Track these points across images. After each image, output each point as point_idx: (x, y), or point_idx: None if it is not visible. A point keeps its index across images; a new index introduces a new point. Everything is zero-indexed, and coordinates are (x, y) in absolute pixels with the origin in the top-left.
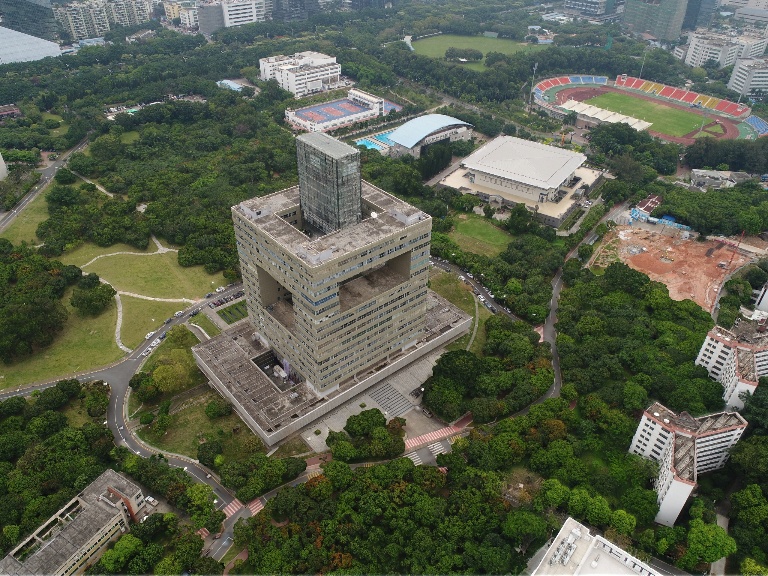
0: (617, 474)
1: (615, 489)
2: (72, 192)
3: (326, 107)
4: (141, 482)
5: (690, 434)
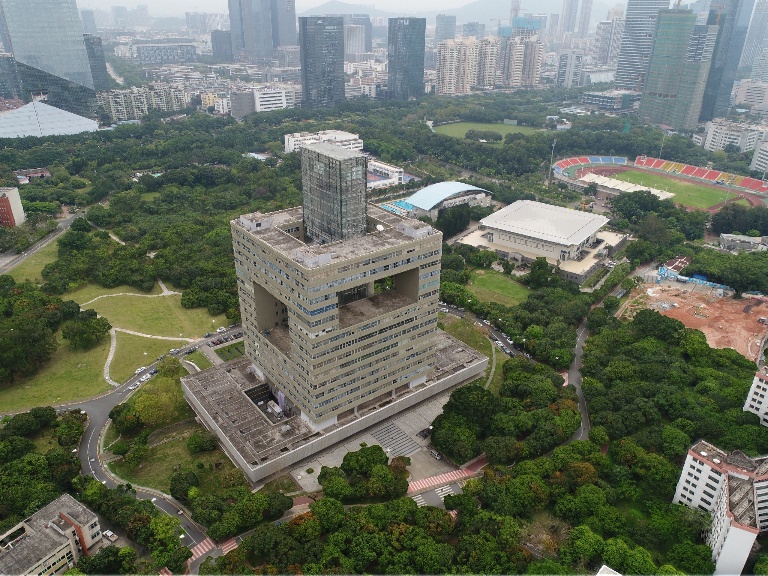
0: (660, 525)
1: (659, 543)
2: (84, 237)
3: None
4: (100, 512)
5: (746, 475)
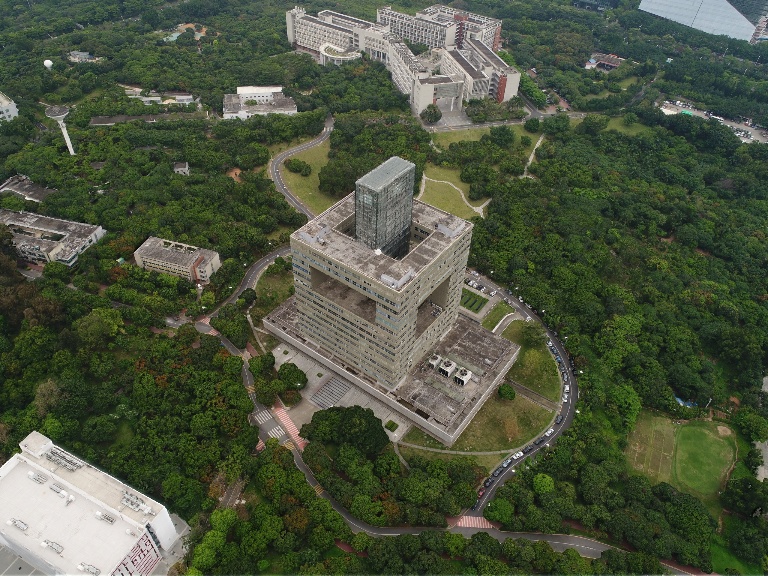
0: None
1: None
2: (506, 135)
3: None
4: None
5: None
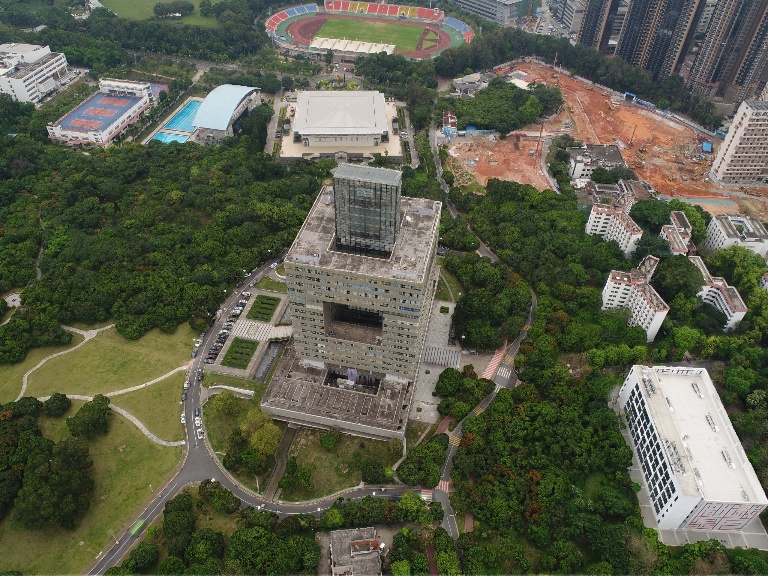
0: (614, 327)
1: None
2: None
3: (87, 109)
4: (356, 525)
5: None
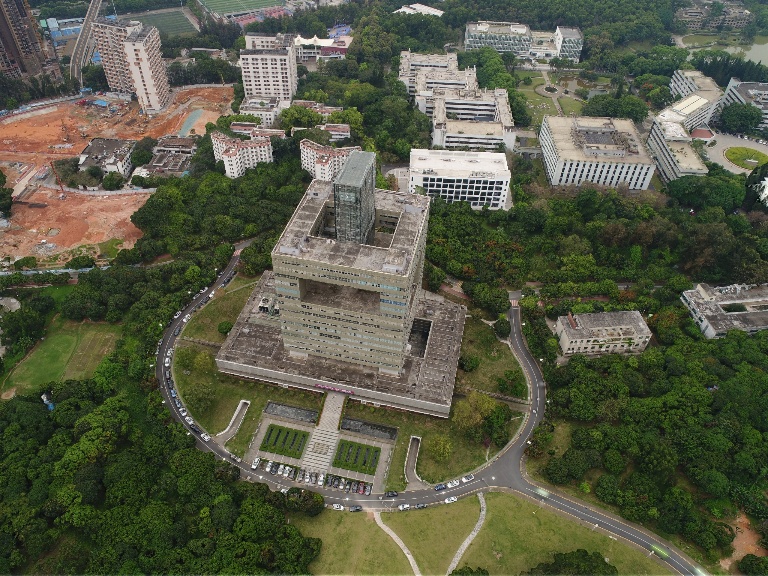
0: None
1: None
2: None
3: None
4: None
5: None
